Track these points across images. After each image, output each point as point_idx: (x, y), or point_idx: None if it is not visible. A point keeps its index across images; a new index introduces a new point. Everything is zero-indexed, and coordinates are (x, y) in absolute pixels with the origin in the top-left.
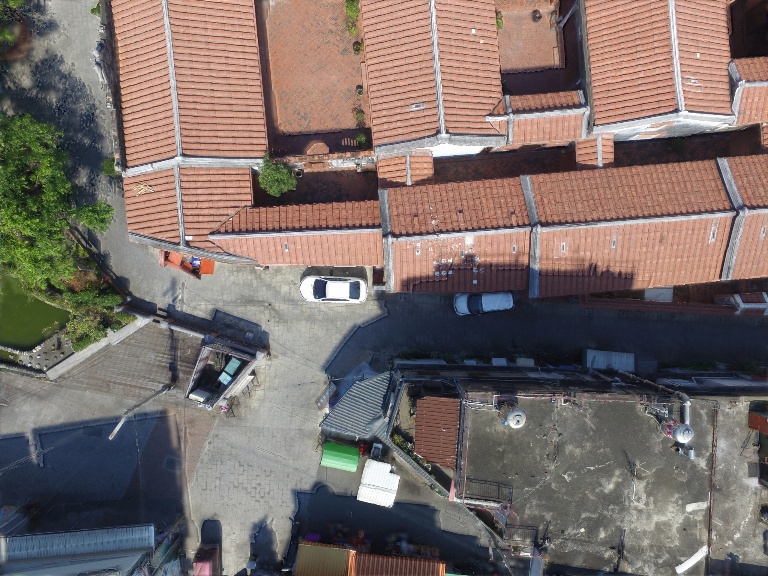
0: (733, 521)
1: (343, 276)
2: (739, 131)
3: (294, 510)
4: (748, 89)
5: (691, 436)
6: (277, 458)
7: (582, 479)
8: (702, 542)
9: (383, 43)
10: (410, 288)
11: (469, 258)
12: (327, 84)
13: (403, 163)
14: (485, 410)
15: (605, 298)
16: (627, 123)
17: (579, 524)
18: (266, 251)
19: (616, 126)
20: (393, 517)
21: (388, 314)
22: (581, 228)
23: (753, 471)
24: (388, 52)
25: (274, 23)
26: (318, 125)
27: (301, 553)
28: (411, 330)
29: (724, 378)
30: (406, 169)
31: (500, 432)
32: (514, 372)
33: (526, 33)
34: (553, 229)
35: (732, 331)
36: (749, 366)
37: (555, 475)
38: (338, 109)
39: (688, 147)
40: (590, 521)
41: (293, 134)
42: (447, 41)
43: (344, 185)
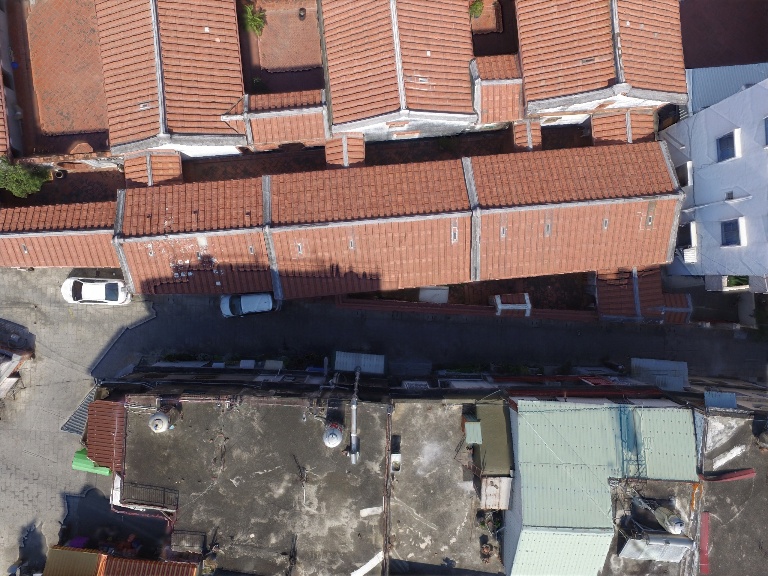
0: (448, 526)
1: (106, 278)
2: (507, 130)
3: (63, 514)
4: (487, 87)
5: (338, 440)
6: (45, 461)
7: (250, 484)
8: (378, 548)
9: (114, 42)
10: (152, 290)
11: (206, 259)
12: (90, 84)
13: (145, 163)
14: (149, 414)
15: (362, 299)
16: (359, 122)
17: (248, 529)
18: (5, 253)
19: (350, 125)
20: (165, 521)
21: (156, 316)
22: (314, 229)
23: (468, 475)
24: (119, 51)
25: (35, 22)
26: (81, 125)
27: (51, 558)
28: (180, 332)
29: (470, 380)
30: (147, 169)
31: (165, 436)
32: (247, 375)
33: (293, 32)
34: (283, 230)
35: (509, 332)
36: (513, 368)
37: (222, 480)
38: (101, 109)
39: (461, 146)
40: (260, 526)
41: (56, 134)
42: (173, 40)
43: (109, 186)
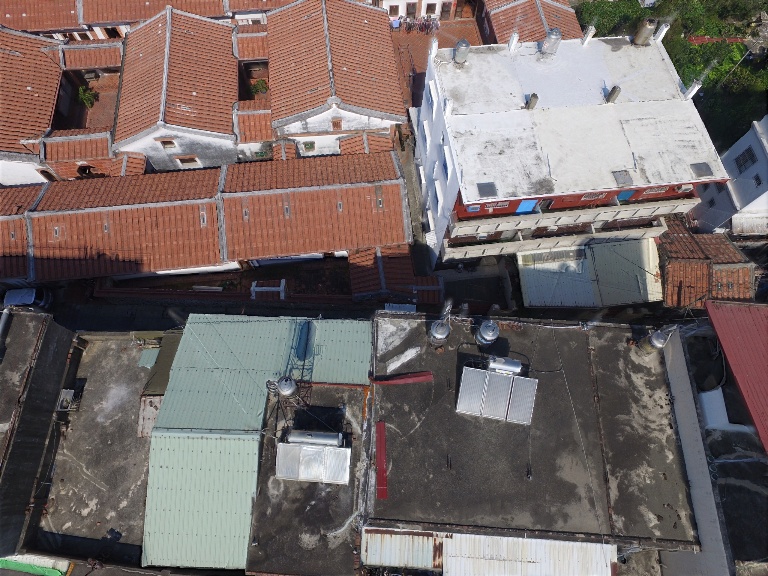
0: (121, 485)
1: None
2: None
3: None
4: (243, 116)
5: None
6: None
7: None
8: None
9: None
10: None
11: None
12: None
13: None
14: None
15: (121, 288)
16: (130, 138)
17: None
18: None
19: (124, 142)
20: None
21: None
22: (71, 214)
23: None
24: None
25: None
26: None
27: None
28: None
29: None
30: None
31: None
32: None
33: None
34: (41, 214)
35: None
36: None
37: None
38: None
39: None
40: None
41: None
42: None
43: None
